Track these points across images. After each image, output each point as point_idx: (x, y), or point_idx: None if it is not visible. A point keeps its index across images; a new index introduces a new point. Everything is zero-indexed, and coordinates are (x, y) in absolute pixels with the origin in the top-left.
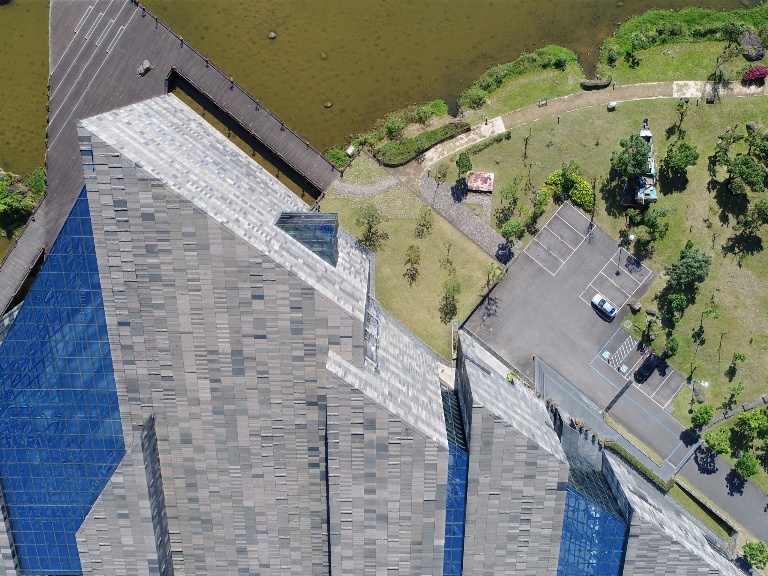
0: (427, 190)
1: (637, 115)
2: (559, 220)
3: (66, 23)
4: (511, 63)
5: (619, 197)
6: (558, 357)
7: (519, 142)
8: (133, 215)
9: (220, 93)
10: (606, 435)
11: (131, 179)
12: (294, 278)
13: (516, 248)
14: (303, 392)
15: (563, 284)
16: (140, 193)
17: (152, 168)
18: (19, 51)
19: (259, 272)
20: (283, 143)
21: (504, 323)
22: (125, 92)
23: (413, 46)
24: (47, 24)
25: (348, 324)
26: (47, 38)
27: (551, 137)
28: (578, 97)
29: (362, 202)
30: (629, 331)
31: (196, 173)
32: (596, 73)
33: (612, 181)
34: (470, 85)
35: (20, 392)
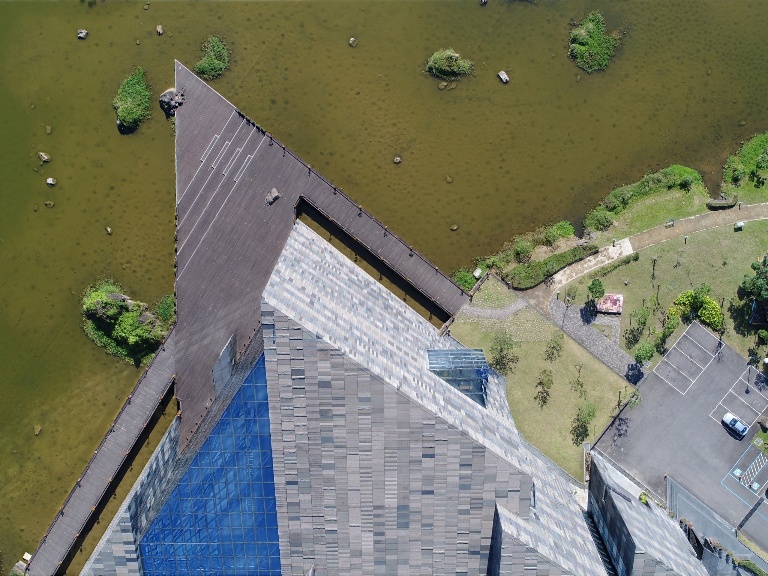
0: (556, 312)
1: (764, 234)
2: (688, 339)
3: (192, 152)
4: (636, 183)
5: (747, 316)
6: (689, 476)
7: (647, 263)
8: (310, 383)
9: (348, 220)
10: (740, 554)
11: (311, 350)
12: (466, 438)
13: (645, 368)
14: (466, 542)
15: (693, 403)
16: (318, 362)
17: (328, 336)
18: (144, 180)
19: (432, 433)
20: (412, 268)
21: (635, 443)
22: (253, 221)
23: (538, 168)
24: (172, 152)
25: (517, 479)
26: (172, 166)
27: (679, 258)
28: (704, 217)
29: (492, 326)
30: (760, 449)
31: (356, 326)
32: (720, 192)
33: (740, 300)
34: (595, 206)
35: (180, 546)
